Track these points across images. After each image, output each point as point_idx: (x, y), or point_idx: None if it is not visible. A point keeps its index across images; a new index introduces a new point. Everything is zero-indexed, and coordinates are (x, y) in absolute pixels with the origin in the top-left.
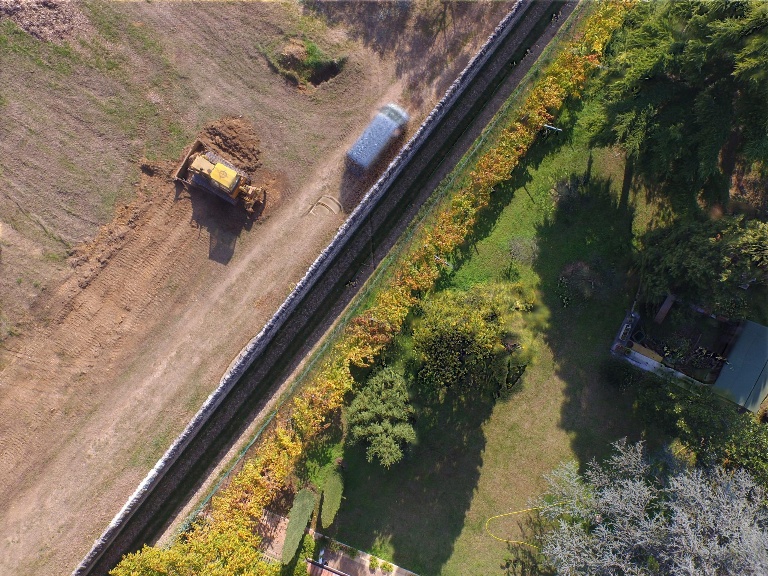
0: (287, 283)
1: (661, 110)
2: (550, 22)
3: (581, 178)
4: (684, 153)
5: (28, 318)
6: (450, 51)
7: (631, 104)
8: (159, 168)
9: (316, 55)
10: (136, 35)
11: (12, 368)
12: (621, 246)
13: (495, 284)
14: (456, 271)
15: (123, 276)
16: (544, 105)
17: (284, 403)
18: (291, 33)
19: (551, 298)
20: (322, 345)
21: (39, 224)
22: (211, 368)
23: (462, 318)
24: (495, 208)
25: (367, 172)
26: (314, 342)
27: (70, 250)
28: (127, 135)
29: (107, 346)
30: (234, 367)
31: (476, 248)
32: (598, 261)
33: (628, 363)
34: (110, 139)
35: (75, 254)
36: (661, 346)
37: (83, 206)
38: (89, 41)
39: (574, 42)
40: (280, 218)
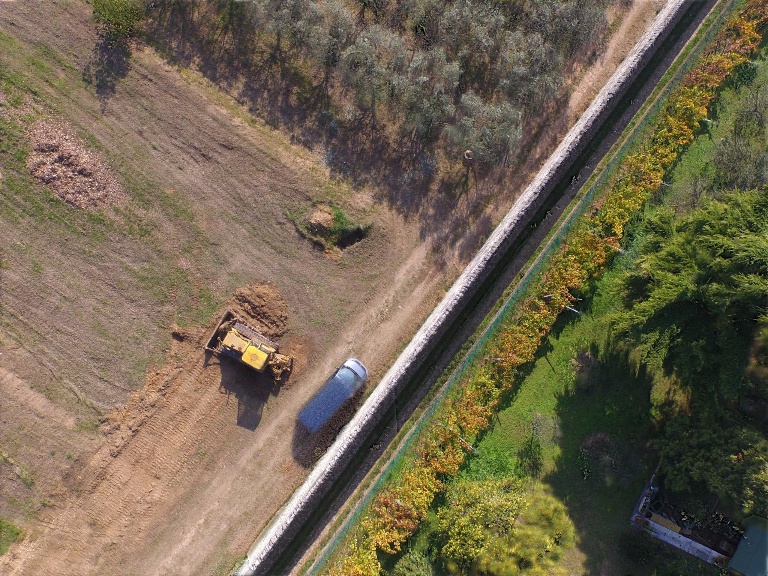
0: (313, 448)
1: (684, 326)
2: (570, 184)
3: (601, 347)
4: (706, 366)
5: (61, 489)
6: (472, 213)
7: (655, 325)
8: (189, 334)
9: (343, 222)
10: (168, 202)
11: (45, 539)
12: (640, 416)
13: (517, 455)
14: (479, 442)
15: (153, 444)
16: (566, 285)
17: (310, 575)
18: (319, 200)
19: (572, 470)
20: (347, 511)
21: (72, 391)
22: (238, 535)
23: (485, 491)
24: (517, 378)
25: (391, 335)
26: (339, 506)
27: (102, 418)
28: (158, 301)
29: (137, 515)
30: (264, 553)
31: (498, 418)
32: (617, 431)
33: (647, 536)
34: (142, 305)
35: (107, 422)
36: (679, 511)
37: (115, 372)
38: (122, 208)
39: (594, 209)
40: (306, 382)
